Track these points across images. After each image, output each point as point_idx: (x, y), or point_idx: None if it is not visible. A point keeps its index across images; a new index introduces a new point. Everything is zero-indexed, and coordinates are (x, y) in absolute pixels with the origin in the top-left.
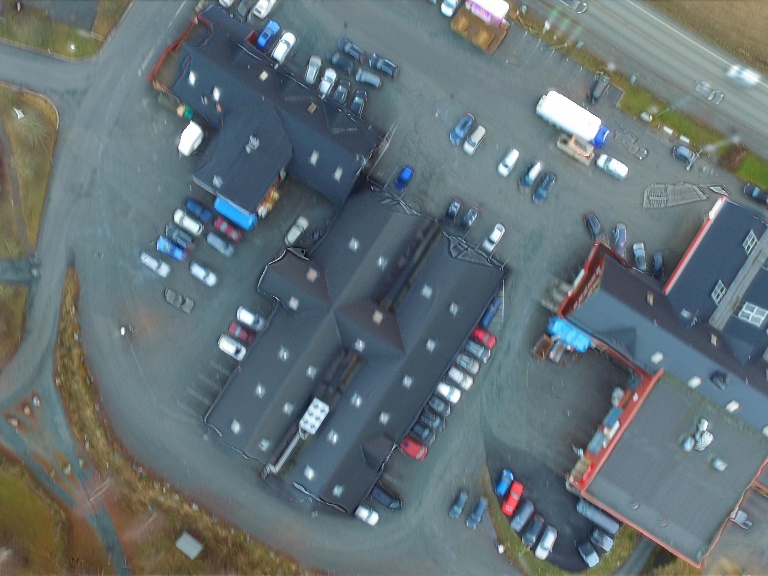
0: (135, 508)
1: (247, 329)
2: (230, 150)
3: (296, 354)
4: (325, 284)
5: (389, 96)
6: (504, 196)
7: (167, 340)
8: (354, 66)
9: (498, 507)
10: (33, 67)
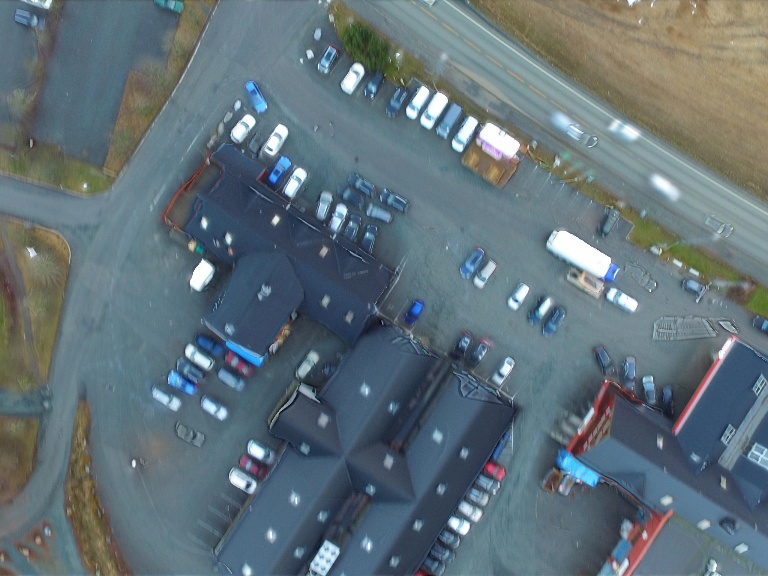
0: None
1: (258, 463)
2: (242, 296)
3: (307, 499)
4: (336, 429)
5: (400, 230)
6: (514, 329)
7: (178, 472)
8: (365, 201)
9: None
10: (45, 203)
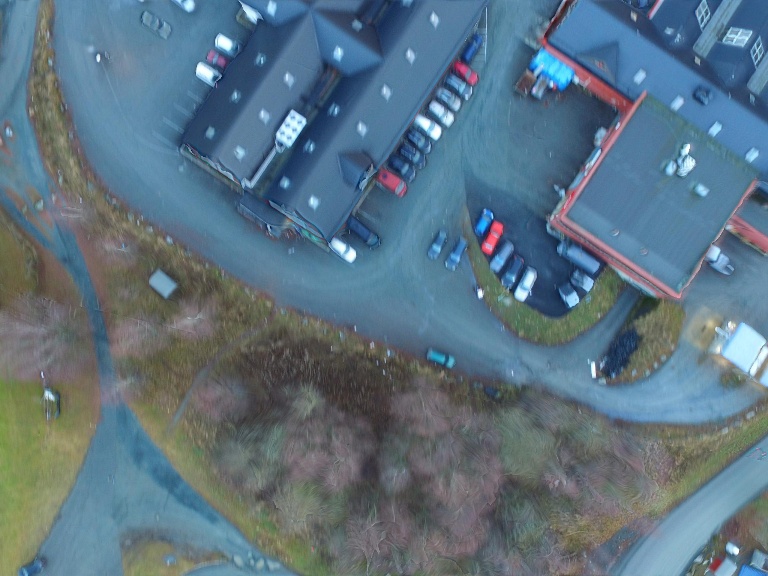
0: (108, 247)
1: (225, 56)
2: None
3: (273, 59)
4: None
5: None
6: None
7: (143, 68)
8: None
9: (478, 247)
10: None
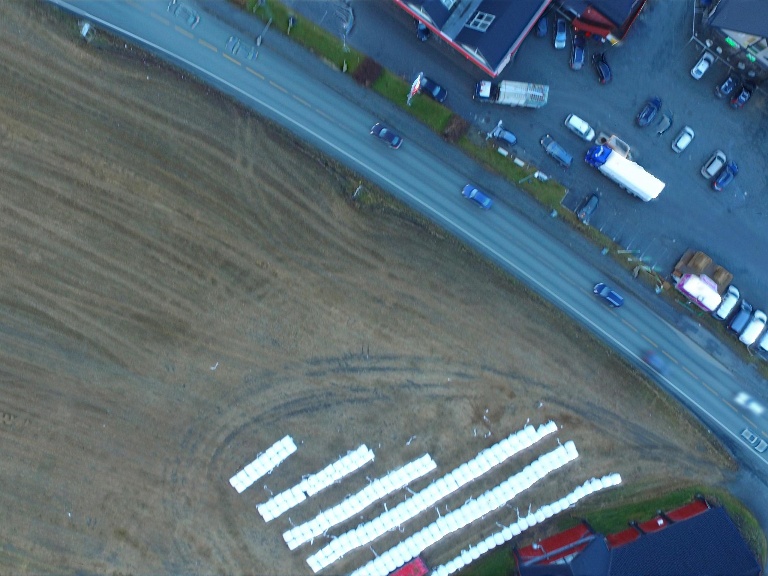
0: None
1: None
2: None
3: None
4: None
5: None
6: (687, 108)
7: None
8: None
9: None
10: None
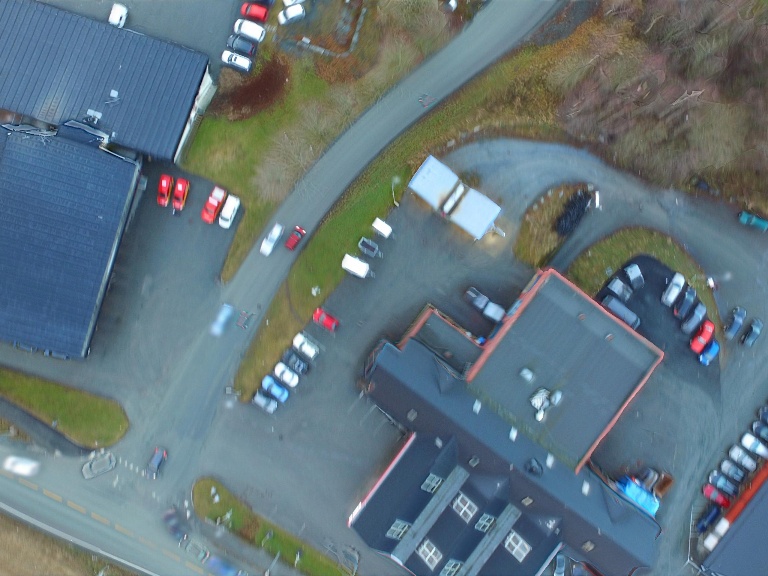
0: None
1: None
2: None
3: None
4: None
5: None
6: None
7: None
8: None
9: None
10: None
